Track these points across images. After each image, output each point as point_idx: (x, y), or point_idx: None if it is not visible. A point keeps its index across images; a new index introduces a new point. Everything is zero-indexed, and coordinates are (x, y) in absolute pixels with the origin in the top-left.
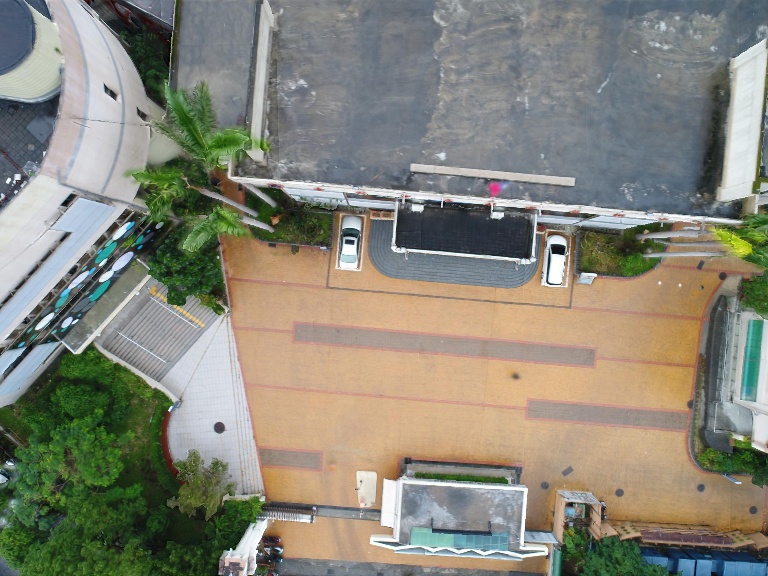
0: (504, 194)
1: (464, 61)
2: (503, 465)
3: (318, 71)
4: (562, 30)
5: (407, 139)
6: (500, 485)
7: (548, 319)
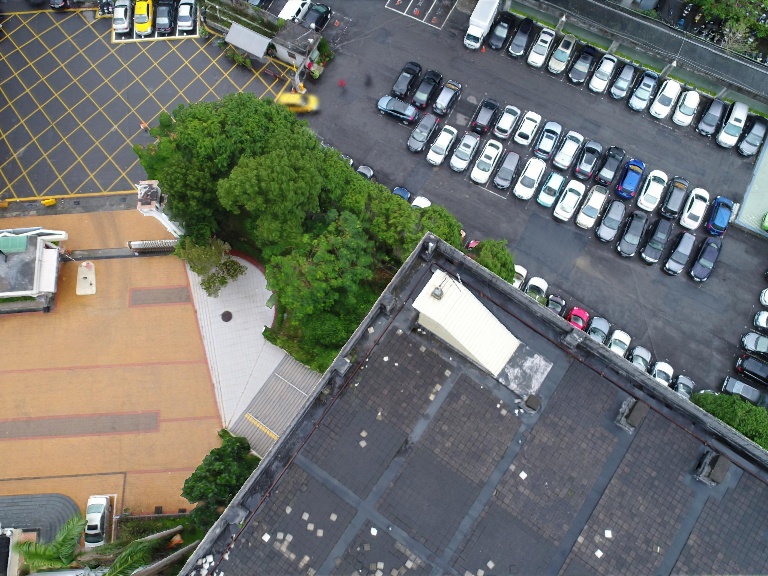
0: None
1: None
2: None
3: None
4: None
5: None
6: None
7: None
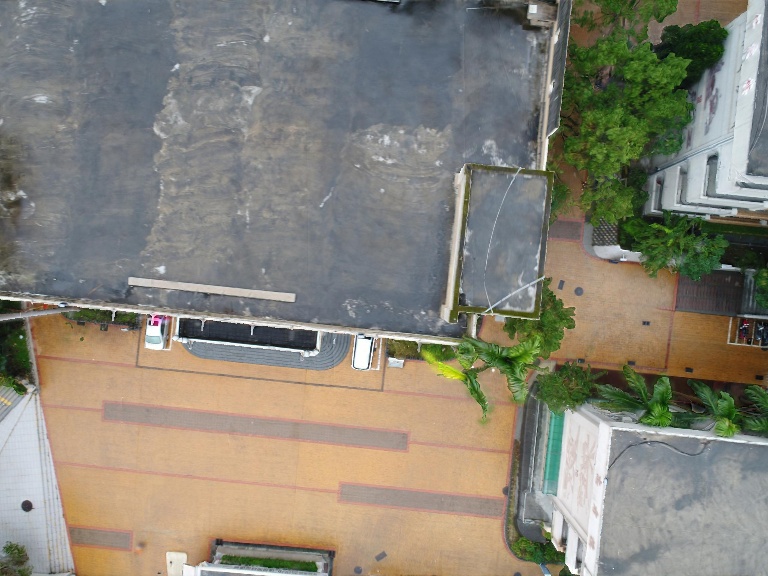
0: (224, 309)
1: (184, 174)
2: (316, 548)
3: (37, 182)
4: (284, 143)
5: (126, 252)
6: (300, 573)
7: (360, 402)
